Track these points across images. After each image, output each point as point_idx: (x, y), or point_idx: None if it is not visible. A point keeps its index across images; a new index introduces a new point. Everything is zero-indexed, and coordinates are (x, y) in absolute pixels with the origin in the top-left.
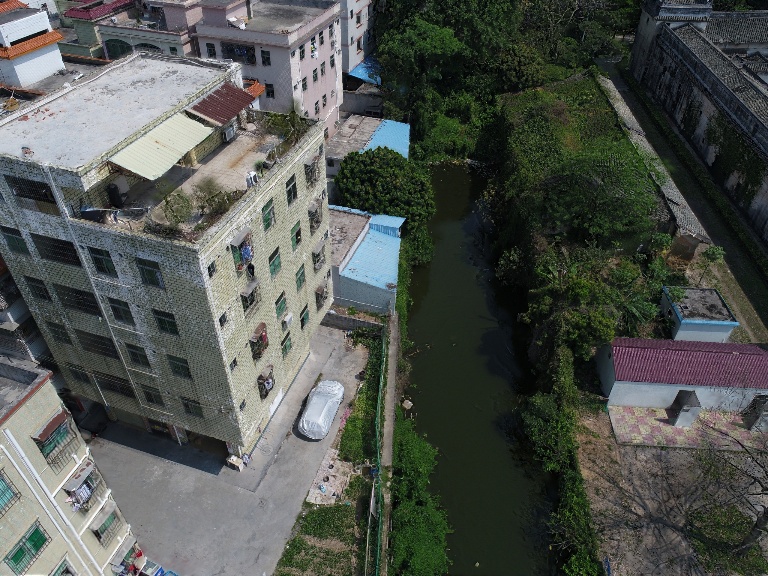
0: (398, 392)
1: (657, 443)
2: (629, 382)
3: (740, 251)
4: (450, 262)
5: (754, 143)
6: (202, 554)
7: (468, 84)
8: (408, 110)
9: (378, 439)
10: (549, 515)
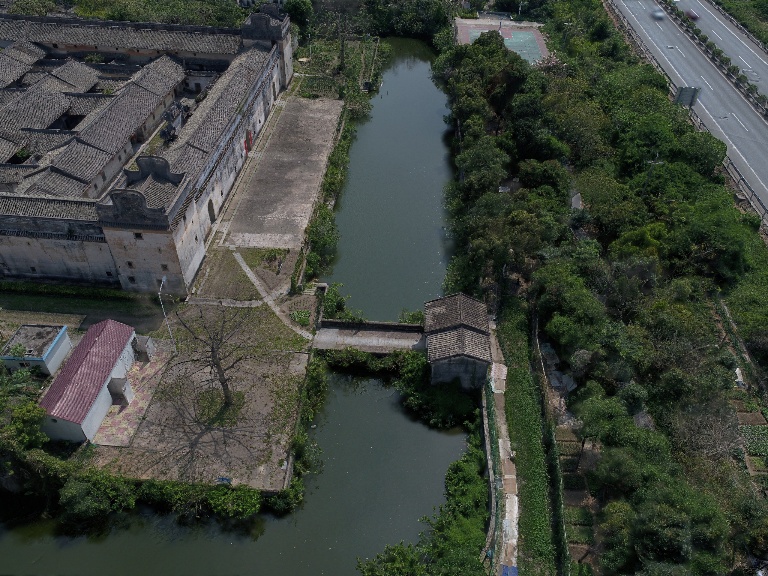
0: None
1: (139, 420)
2: (86, 416)
3: None
4: None
5: None
6: None
7: None
8: None
9: None
10: (169, 515)
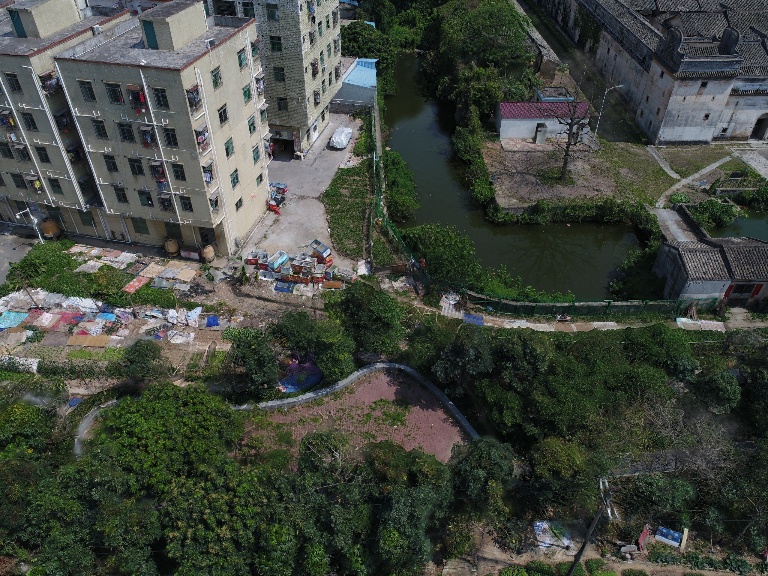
0: (382, 140)
1: (526, 150)
2: (509, 119)
3: (588, 81)
4: (408, 99)
5: (595, 17)
6: (290, 184)
7: (413, 7)
8: (373, 15)
9: (374, 139)
10: None
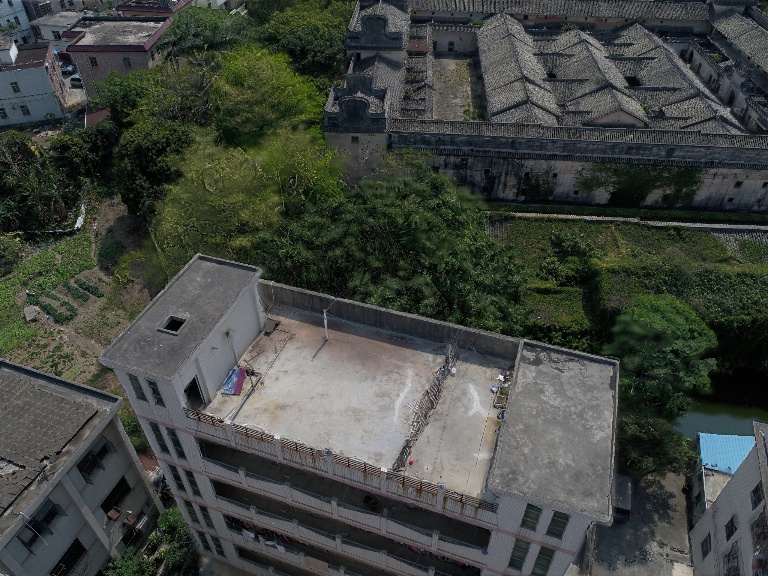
0: None
1: None
2: None
3: None
4: None
5: (677, 161)
6: None
7: None
8: None
9: None
10: None
